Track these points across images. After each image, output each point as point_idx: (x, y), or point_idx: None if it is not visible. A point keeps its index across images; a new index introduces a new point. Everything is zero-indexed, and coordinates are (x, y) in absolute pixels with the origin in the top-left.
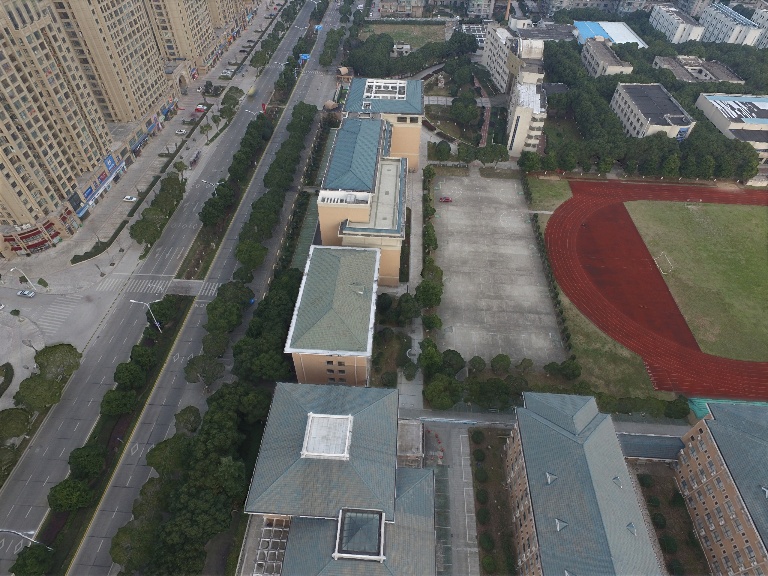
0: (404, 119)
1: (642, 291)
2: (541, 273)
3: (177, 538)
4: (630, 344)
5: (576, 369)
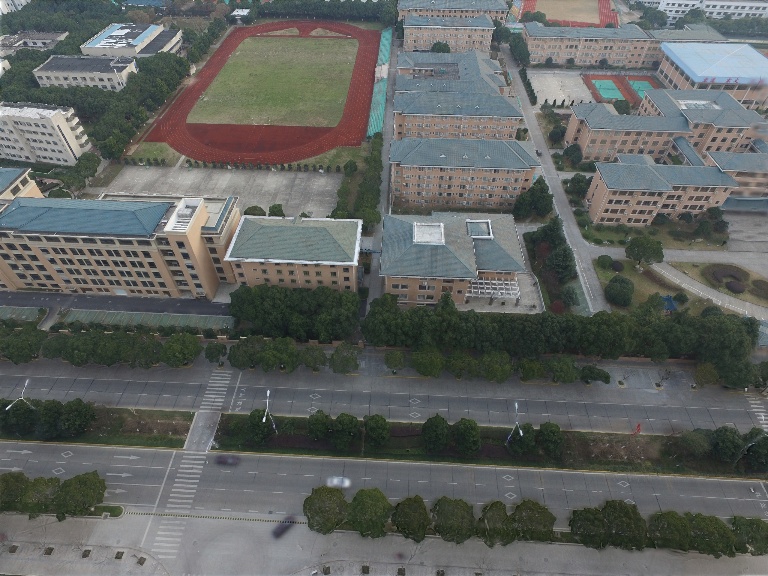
0: (16, 188)
1: (284, 135)
2: (255, 171)
3: (495, 323)
4: (327, 148)
5: (353, 162)
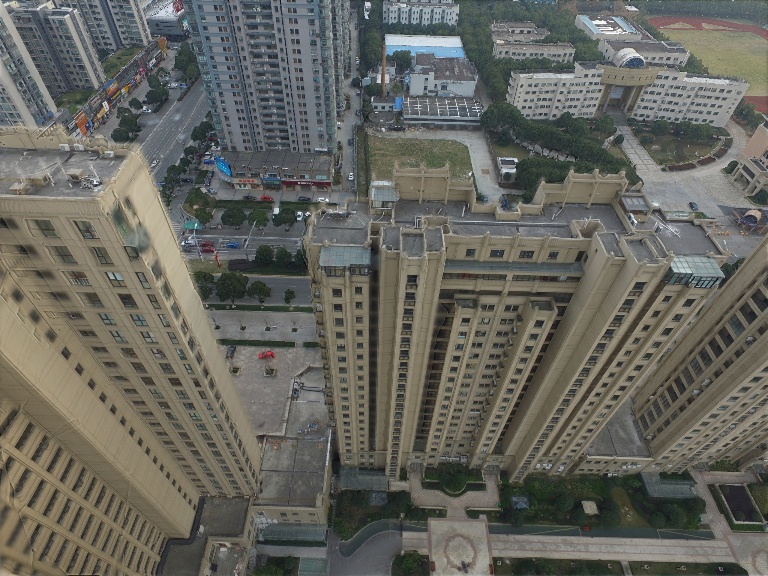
0: None
1: None
2: None
3: None
4: None
5: None
